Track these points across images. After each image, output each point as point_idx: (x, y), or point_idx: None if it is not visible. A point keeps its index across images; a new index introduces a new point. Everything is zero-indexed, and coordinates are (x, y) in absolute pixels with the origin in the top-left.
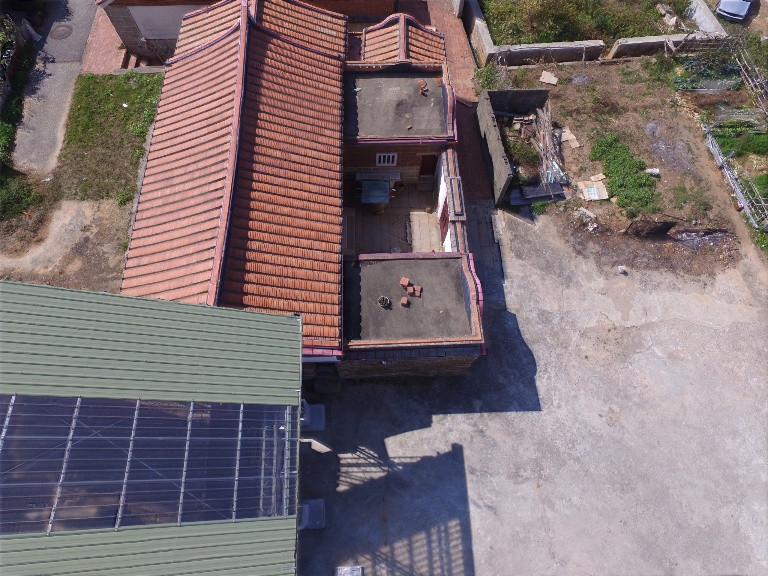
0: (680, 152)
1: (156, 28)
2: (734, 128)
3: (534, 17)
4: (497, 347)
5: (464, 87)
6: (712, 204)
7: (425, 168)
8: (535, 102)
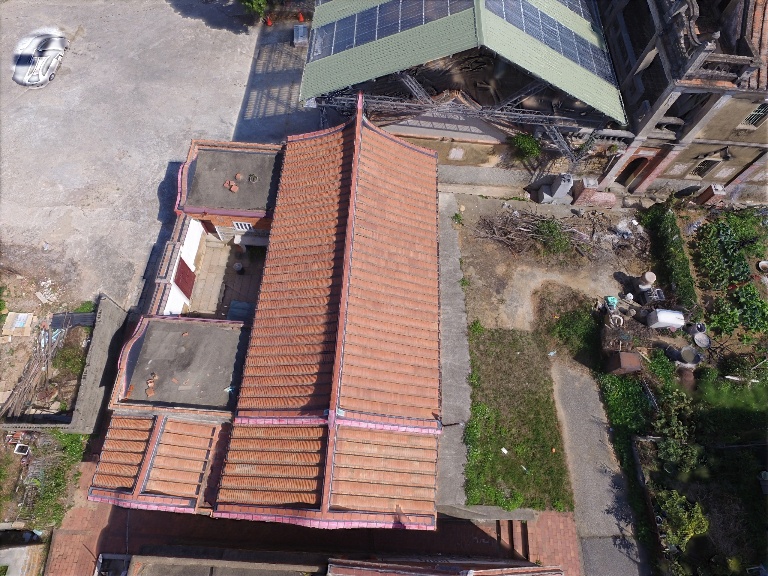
0: None
1: None
2: None
3: None
4: None
5: None
6: None
7: None
8: None
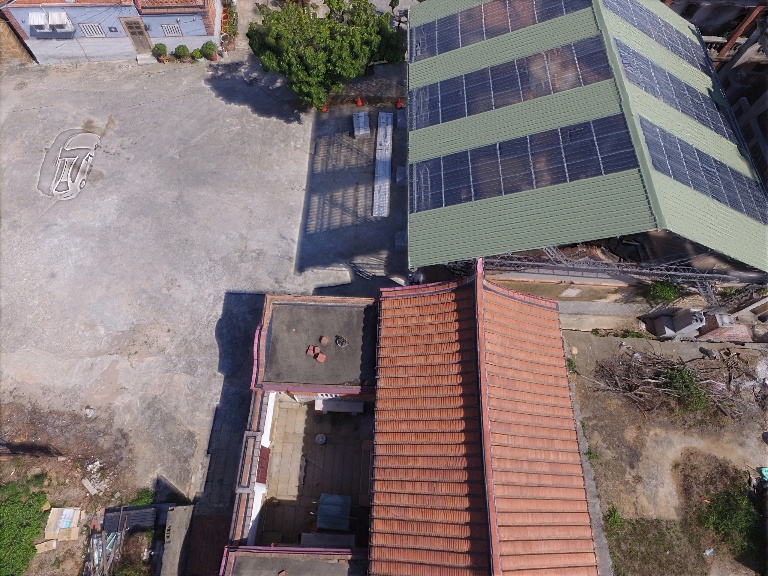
0: None
1: None
2: None
3: None
4: (245, 344)
5: None
6: None
7: None
8: None
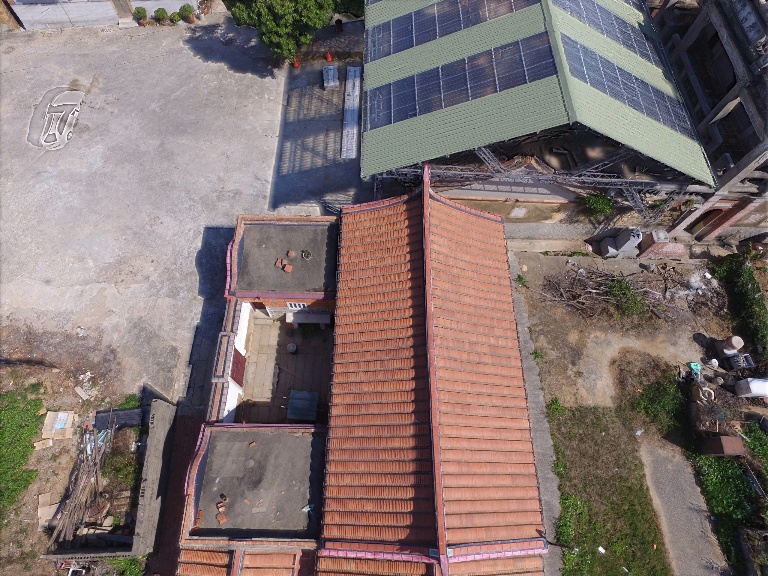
0: None
1: None
2: None
3: None
4: (222, 271)
5: None
6: None
7: None
8: (69, 550)
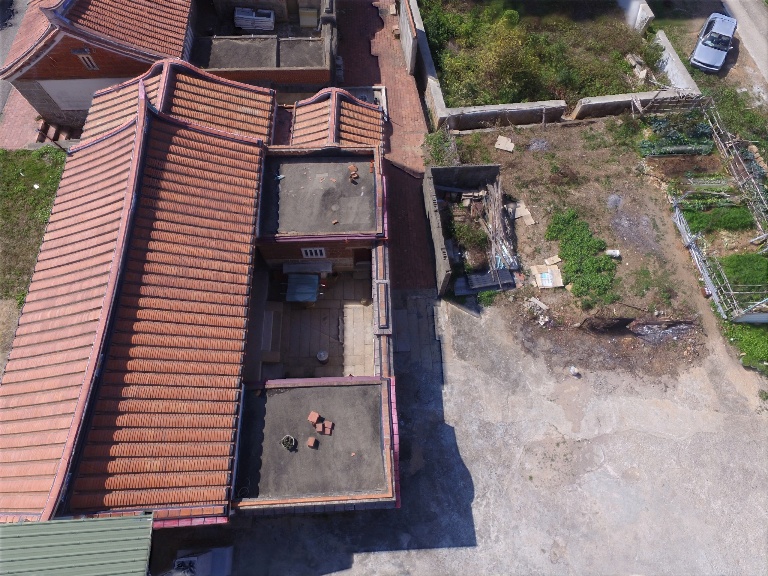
0: (644, 229)
1: (72, 100)
2: (704, 200)
3: (493, 72)
4: (431, 468)
5: (412, 155)
6: (677, 291)
7: (360, 257)
8: (485, 177)
